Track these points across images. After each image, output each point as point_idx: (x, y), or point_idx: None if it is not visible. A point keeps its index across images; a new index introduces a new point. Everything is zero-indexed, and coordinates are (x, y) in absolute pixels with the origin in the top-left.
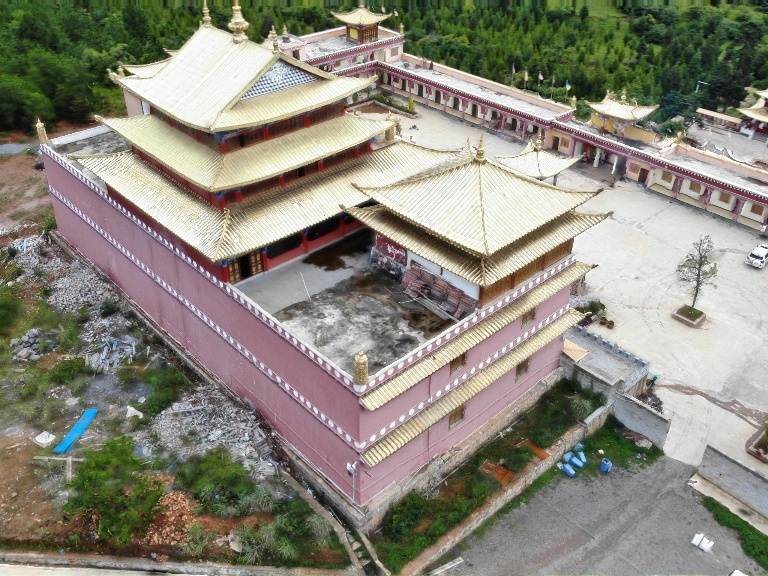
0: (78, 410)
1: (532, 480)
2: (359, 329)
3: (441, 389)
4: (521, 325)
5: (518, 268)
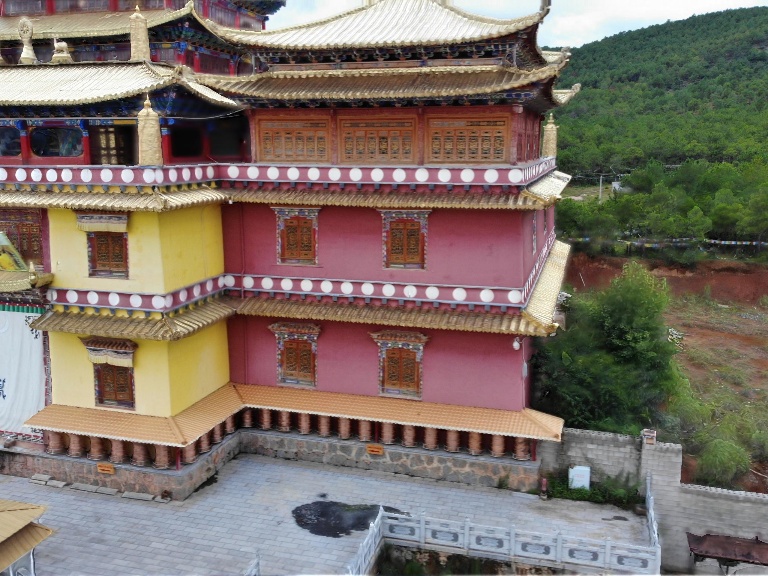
0: None
1: None
2: None
3: None
4: None
5: None
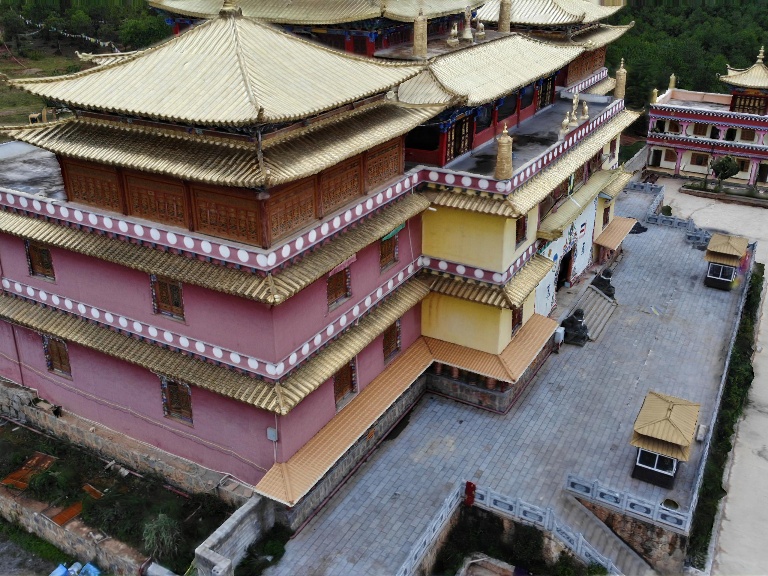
0: None
1: (33, 529)
2: (56, 171)
3: (21, 283)
4: (154, 306)
5: (76, 153)
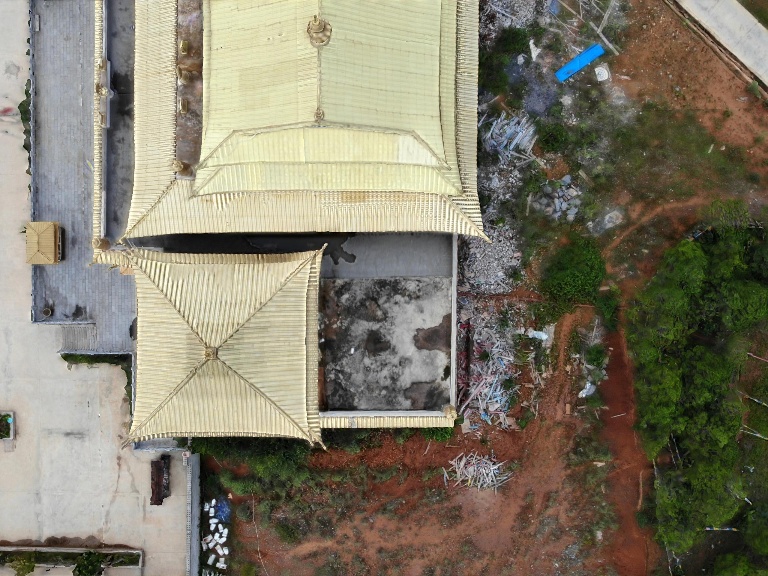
0: (567, 87)
1: None
2: None
3: None
4: None
5: None
